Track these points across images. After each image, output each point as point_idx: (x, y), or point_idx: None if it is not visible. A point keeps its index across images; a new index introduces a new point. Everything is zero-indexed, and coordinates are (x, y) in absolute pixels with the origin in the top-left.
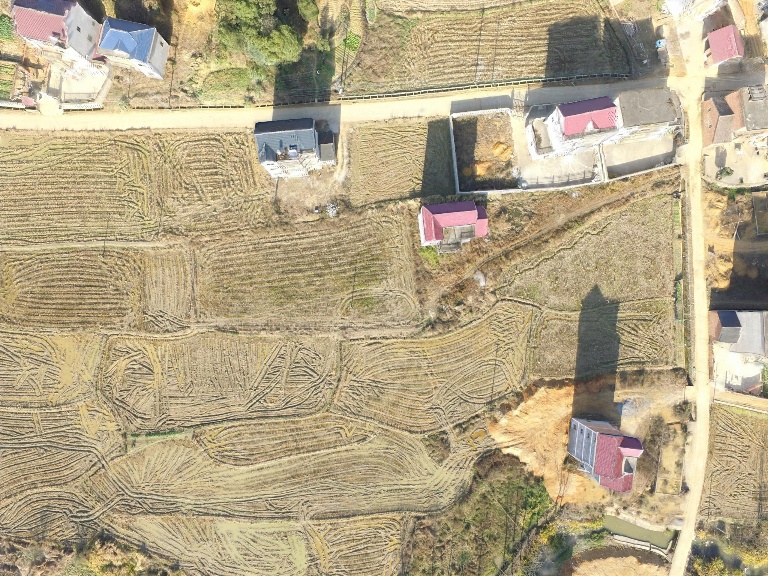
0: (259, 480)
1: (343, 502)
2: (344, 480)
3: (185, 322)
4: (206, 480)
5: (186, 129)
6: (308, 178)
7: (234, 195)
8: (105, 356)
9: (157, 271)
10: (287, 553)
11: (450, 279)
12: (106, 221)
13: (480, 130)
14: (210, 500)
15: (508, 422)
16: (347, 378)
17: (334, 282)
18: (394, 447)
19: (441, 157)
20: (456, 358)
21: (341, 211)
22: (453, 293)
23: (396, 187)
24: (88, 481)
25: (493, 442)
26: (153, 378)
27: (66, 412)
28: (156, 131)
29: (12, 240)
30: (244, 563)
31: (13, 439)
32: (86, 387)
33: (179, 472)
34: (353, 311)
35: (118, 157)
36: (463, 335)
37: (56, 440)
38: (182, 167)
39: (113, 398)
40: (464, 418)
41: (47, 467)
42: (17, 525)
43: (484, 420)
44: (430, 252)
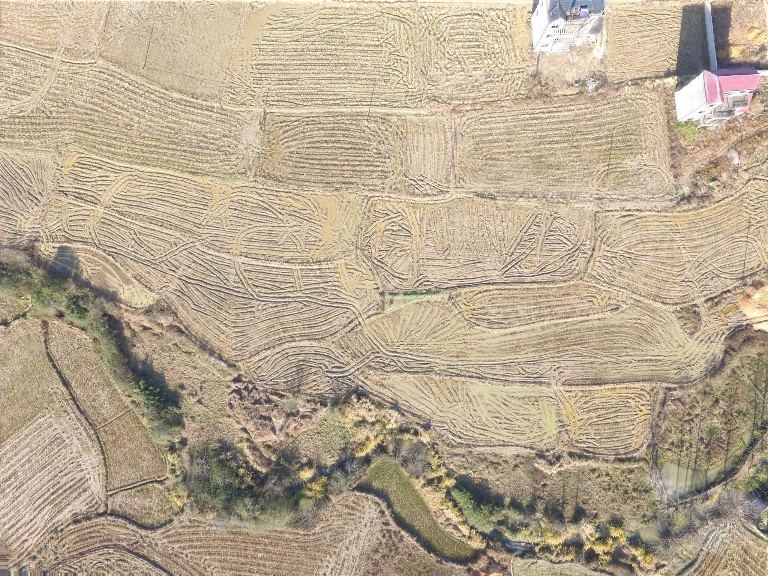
0: (512, 344)
1: (595, 370)
2: (596, 348)
3: (444, 187)
4: (460, 342)
5: (451, 3)
6: (568, 53)
7: (495, 67)
8: (365, 217)
9: (418, 137)
10: (537, 418)
11: (704, 156)
12: (371, 87)
13: (734, 15)
14: (463, 361)
15: (761, 298)
16: (601, 248)
17: (590, 154)
18: (645, 318)
19: (695, 40)
20: (708, 233)
21: (600, 86)
22: (707, 169)
23: (651, 66)
24: (345, 337)
25: (744, 317)
26: (411, 240)
27: (326, 269)
28: (422, 4)
29: (281, 102)
30: (495, 426)
31: (273, 293)
32: (346, 245)
33: (433, 333)
34: (608, 183)
35: (384, 28)
36: (715, 212)
37: (315, 296)
38: (445, 39)
39: (372, 257)
40: (716, 292)
41: (306, 321)
42: (273, 377)
43: (735, 295)
44: (689, 127)
